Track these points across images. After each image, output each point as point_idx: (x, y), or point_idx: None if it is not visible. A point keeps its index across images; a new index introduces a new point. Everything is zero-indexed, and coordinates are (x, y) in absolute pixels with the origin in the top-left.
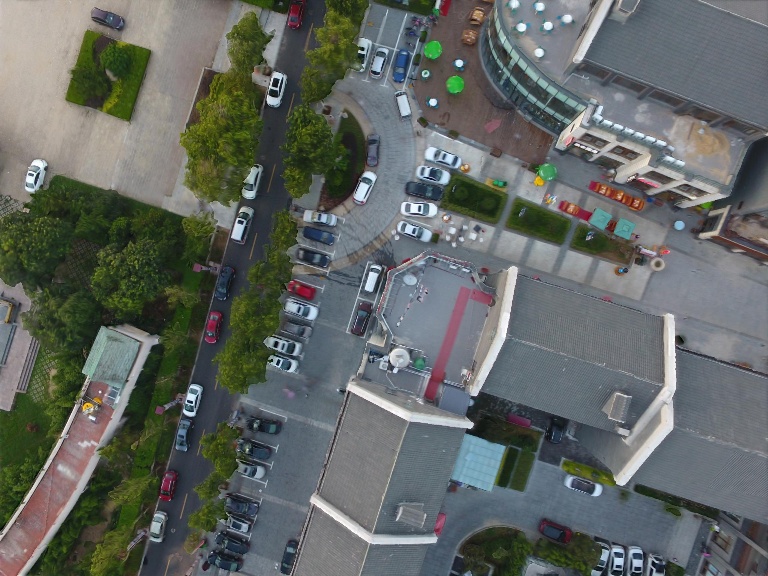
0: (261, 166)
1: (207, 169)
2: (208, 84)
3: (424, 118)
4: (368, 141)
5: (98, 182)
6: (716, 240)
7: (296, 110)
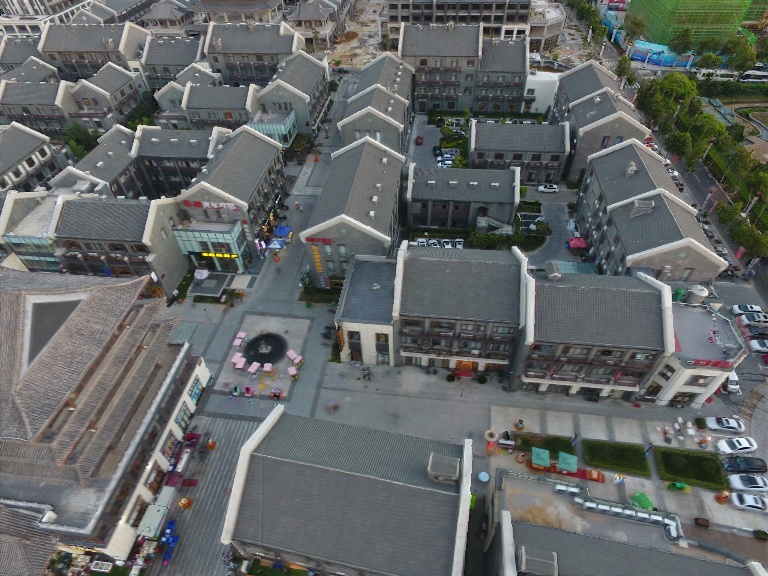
0: None
1: None
2: None
3: None
4: None
5: None
6: None
7: None
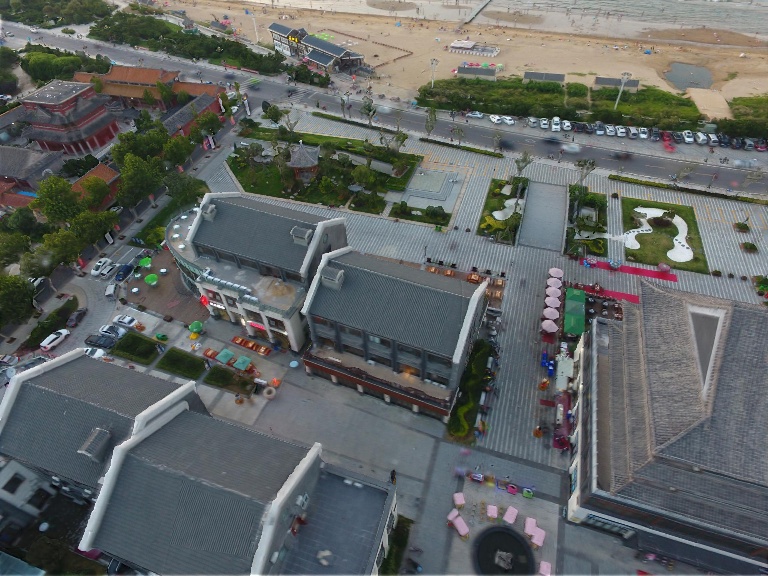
0: None
1: None
2: None
3: (126, 300)
4: (76, 311)
5: None
6: (319, 373)
7: None
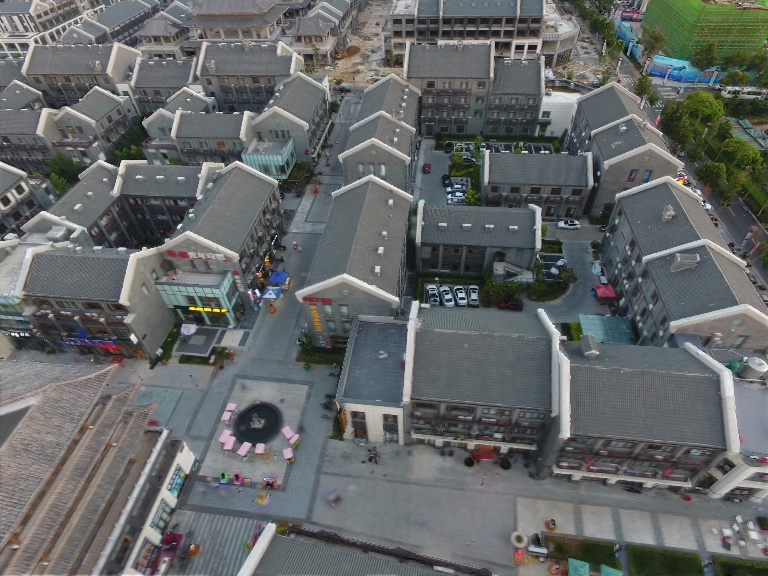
0: None
1: None
2: None
3: None
4: None
5: None
6: None
7: None
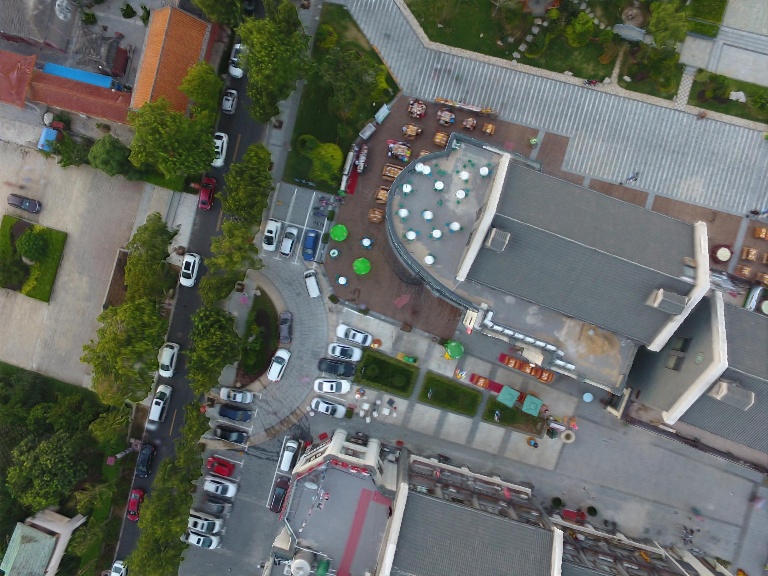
0: (177, 345)
1: (106, 387)
2: (123, 266)
3: (335, 294)
4: (280, 320)
5: (20, 362)
6: None
7: (198, 313)
